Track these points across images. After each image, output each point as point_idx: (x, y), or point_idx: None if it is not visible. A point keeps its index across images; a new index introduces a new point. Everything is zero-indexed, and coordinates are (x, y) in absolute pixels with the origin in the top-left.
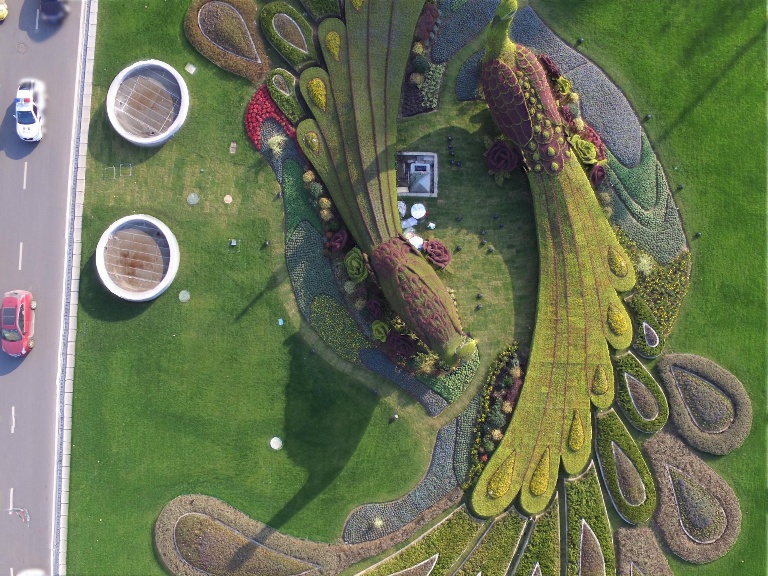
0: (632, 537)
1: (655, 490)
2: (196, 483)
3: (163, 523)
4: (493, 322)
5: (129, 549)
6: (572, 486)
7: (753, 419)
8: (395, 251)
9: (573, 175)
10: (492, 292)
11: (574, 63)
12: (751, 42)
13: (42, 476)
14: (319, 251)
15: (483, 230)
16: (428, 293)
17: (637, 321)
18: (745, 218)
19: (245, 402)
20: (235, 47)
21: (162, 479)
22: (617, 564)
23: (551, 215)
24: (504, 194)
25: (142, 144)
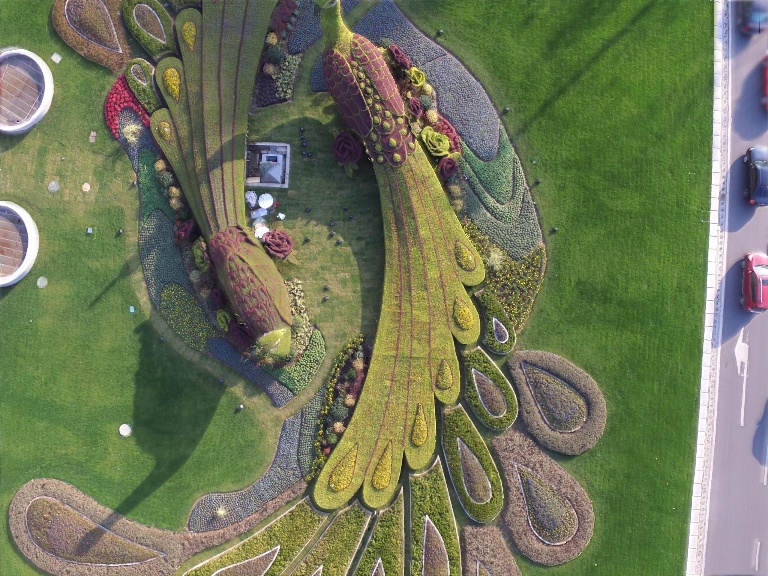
0: (478, 536)
1: (504, 489)
2: (48, 467)
3: (16, 506)
4: (340, 314)
5: None
6: (416, 482)
7: (608, 419)
8: (229, 240)
9: (417, 167)
10: (340, 284)
11: (432, 55)
12: (618, 35)
13: None
14: (170, 240)
15: (332, 221)
16: (255, 282)
17: (486, 316)
18: (605, 214)
19: (96, 388)
20: (98, 37)
21: (17, 462)
22: (464, 563)
23: (395, 207)
24: (355, 185)
25: (7, 132)
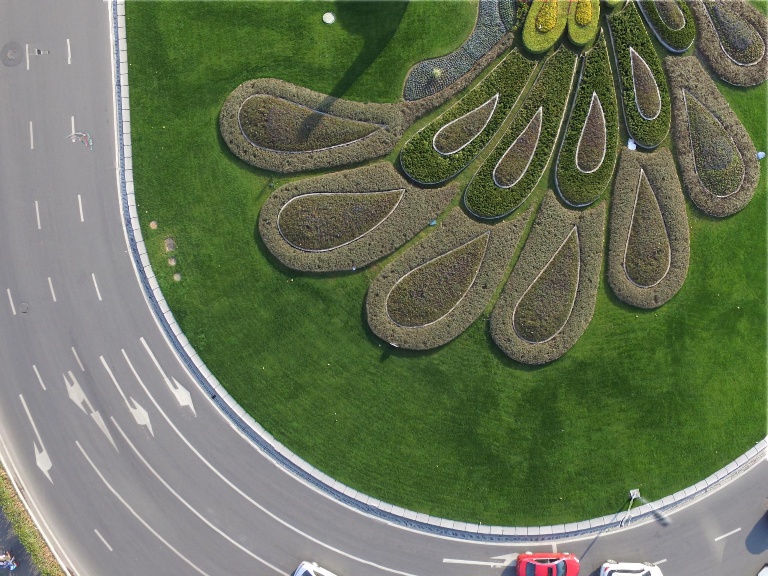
0: (679, 63)
1: None
2: (255, 70)
3: (227, 111)
4: None
5: (195, 148)
6: (615, 17)
7: None
8: None
9: None
10: None
11: None
12: None
13: (101, 101)
14: None
15: None
16: None
17: None
18: None
19: None
20: None
21: (221, 74)
22: (669, 93)
23: None
24: None
25: None
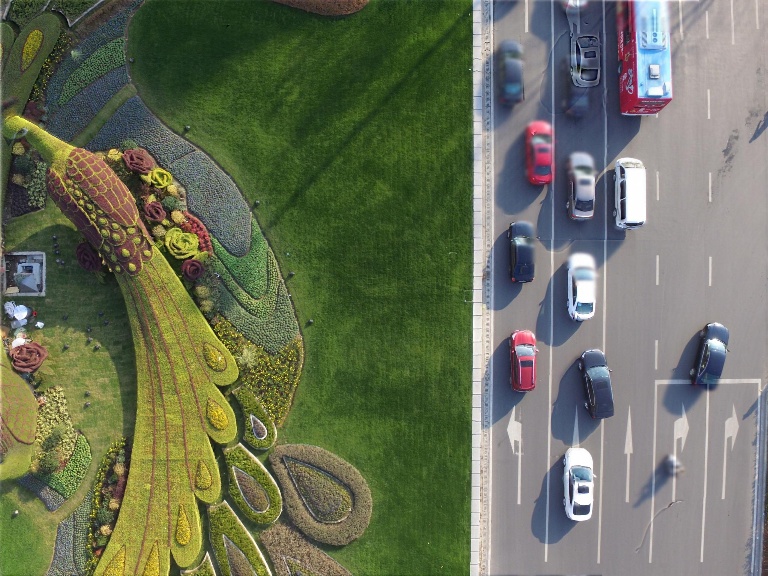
0: None
1: None
2: None
3: None
4: (102, 418)
5: None
6: None
7: (376, 507)
8: None
9: (155, 274)
10: (100, 389)
11: (181, 152)
12: (370, 116)
13: None
14: None
15: (89, 327)
16: None
17: (244, 413)
18: (362, 302)
19: None
20: None
21: None
22: None
23: (140, 314)
24: (109, 290)
25: None
